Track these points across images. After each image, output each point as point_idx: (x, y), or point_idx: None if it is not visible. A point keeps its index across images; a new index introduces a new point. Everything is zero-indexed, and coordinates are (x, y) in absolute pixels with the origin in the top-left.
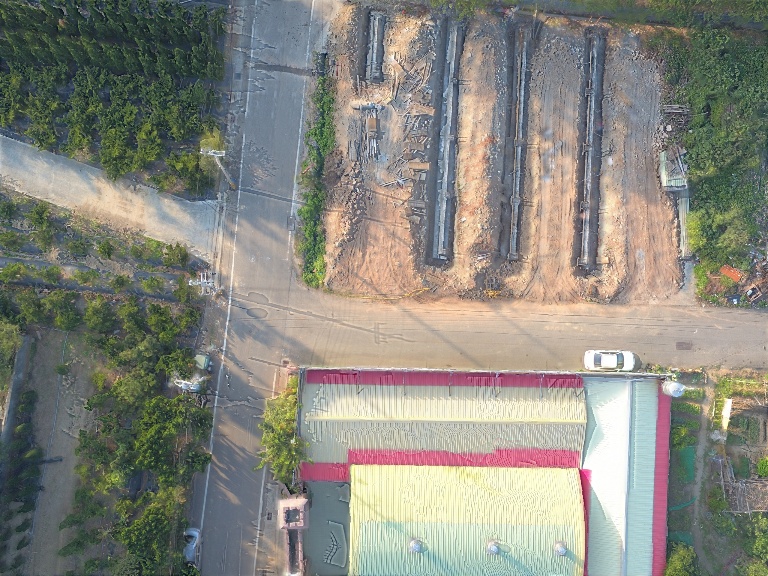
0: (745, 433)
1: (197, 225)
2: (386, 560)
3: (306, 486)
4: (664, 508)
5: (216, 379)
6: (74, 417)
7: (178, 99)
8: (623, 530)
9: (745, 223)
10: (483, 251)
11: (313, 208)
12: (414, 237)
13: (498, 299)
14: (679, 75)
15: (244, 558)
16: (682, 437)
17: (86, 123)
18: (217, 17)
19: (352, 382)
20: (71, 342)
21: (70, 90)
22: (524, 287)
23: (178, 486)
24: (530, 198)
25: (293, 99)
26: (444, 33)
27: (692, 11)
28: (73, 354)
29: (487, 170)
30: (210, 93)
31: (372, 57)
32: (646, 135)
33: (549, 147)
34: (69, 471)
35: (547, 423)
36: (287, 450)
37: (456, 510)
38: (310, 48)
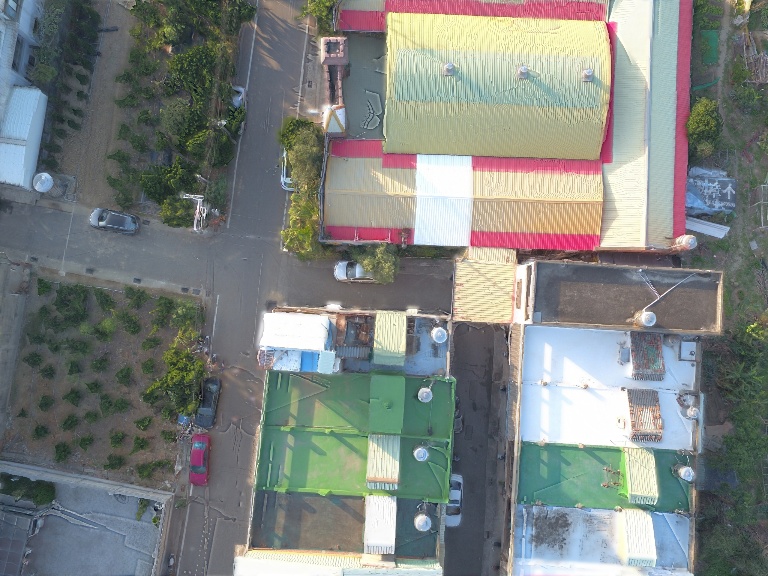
0: (767, 4)
1: None
2: (421, 89)
3: None
4: (688, 62)
5: None
6: None
7: None
8: (648, 71)
9: None
10: None
11: None
12: None
13: None
14: None
15: (286, 121)
16: None
17: None
18: None
19: None
20: None
21: None
22: None
23: None
24: None
25: None
26: None
27: None
28: None
29: None
30: None
31: None
32: None
33: None
34: (124, 40)
35: None
36: None
37: (487, 49)
38: None
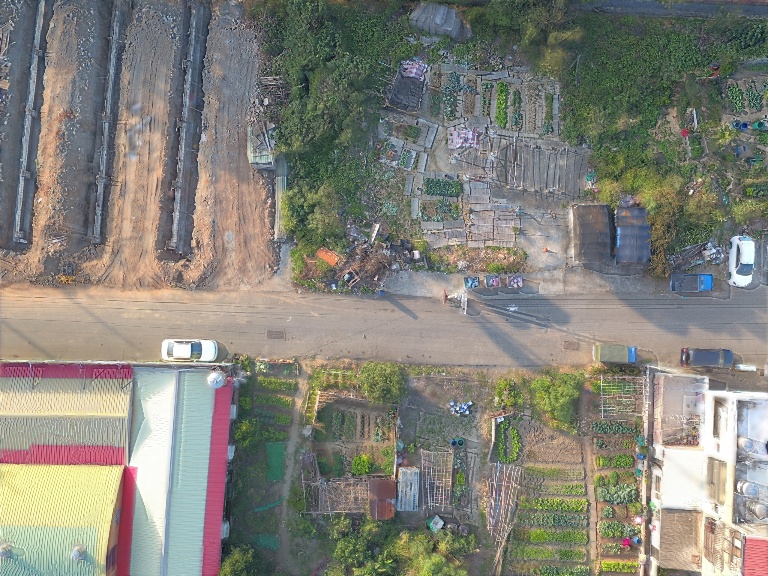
0: (324, 428)
1: None
2: None
3: None
4: (220, 508)
5: None
6: None
7: None
8: (163, 532)
9: (349, 203)
10: (58, 234)
11: None
12: None
13: (73, 285)
14: (282, 45)
15: None
16: (245, 432)
17: None
18: None
19: None
20: None
21: None
22: (102, 272)
23: None
24: (116, 177)
25: None
26: (36, 3)
27: None
28: None
29: (61, 147)
30: None
31: None
32: (240, 109)
33: (136, 123)
34: None
35: (84, 417)
36: None
37: None
38: None
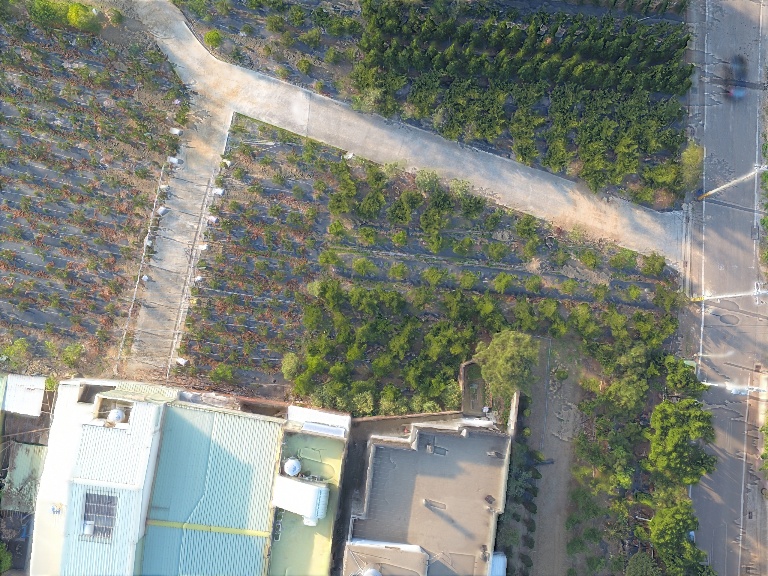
0: None
1: (667, 235)
2: None
3: None
4: None
5: None
6: (563, 421)
7: (652, 114)
8: None
9: None
10: None
11: None
12: None
13: None
14: None
15: (729, 555)
16: None
17: (564, 137)
18: None
19: None
20: (555, 349)
21: (541, 105)
22: None
23: (678, 487)
24: None
25: (749, 112)
26: None
27: None
28: (558, 360)
29: None
30: None
31: None
32: None
33: None
34: (560, 473)
35: None
36: None
37: None
38: (761, 63)
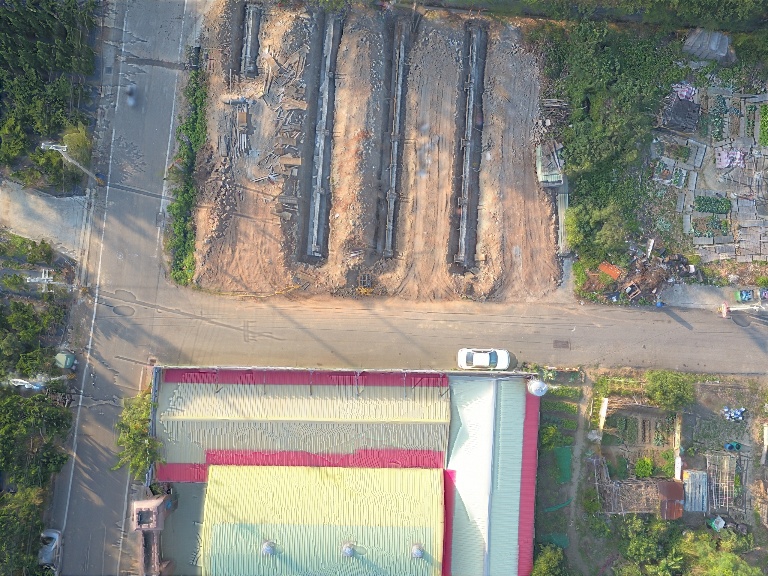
0: (618, 433)
1: (64, 221)
2: (241, 562)
3: (171, 487)
4: (531, 509)
5: (81, 378)
6: None
7: (43, 93)
8: (486, 532)
9: (626, 219)
10: (356, 248)
11: (183, 204)
12: (285, 234)
13: (371, 297)
14: (560, 69)
15: (107, 560)
16: (551, 437)
17: None
18: (87, 10)
19: (211, 381)
20: None
21: None
22: (398, 284)
23: (36, 487)
24: (406, 194)
25: (164, 93)
26: (322, 26)
27: (567, 3)
28: None
29: (360, 165)
30: (78, 87)
31: (246, 51)
32: (524, 130)
33: (425, 142)
34: None
35: (409, 423)
36: (142, 450)
37: (314, 511)
38: (183, 42)
